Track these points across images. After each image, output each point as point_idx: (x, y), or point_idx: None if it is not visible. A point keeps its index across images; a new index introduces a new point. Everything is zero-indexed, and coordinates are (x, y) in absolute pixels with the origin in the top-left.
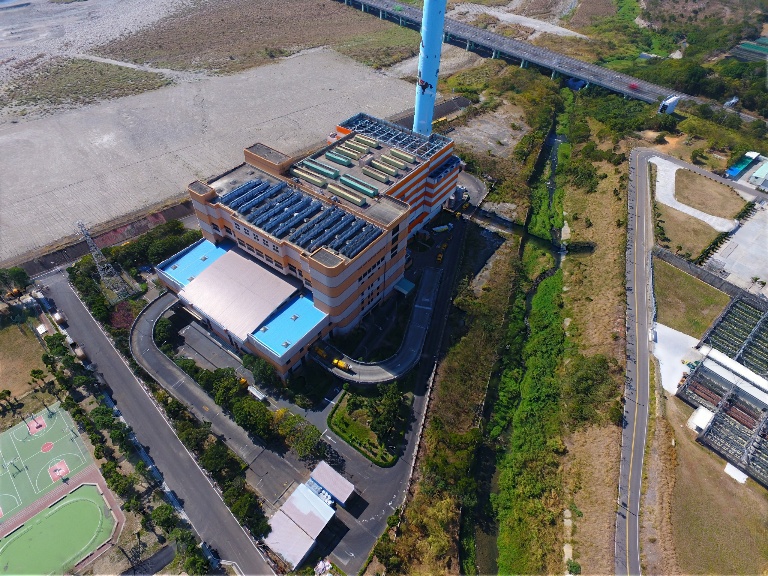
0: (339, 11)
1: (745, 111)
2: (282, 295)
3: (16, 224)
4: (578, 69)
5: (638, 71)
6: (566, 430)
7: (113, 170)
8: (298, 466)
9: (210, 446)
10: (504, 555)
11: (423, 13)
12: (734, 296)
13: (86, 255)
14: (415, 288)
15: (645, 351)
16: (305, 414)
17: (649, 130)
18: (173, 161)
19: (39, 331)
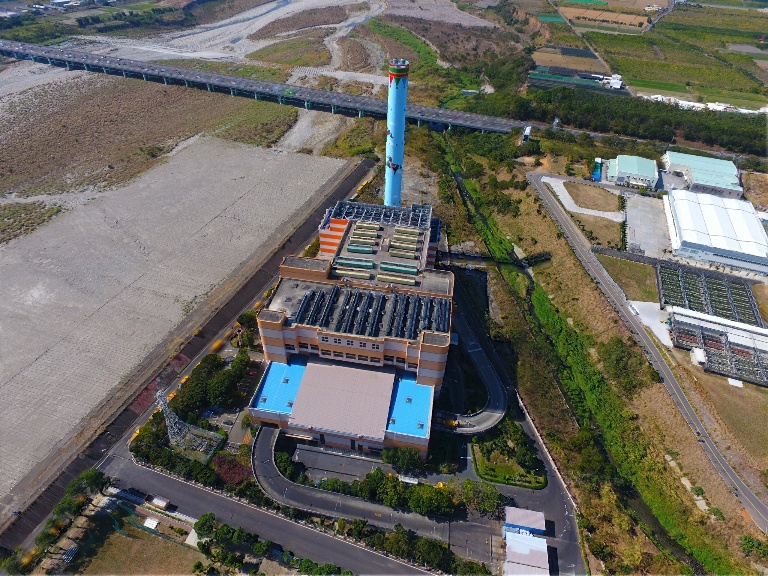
0: (185, 95)
1: (565, 126)
2: (387, 385)
3: (6, 427)
4: (437, 115)
5: (477, 108)
6: (626, 401)
7: (77, 326)
8: (485, 522)
9: (422, 542)
10: (656, 507)
11: (389, 112)
12: (654, 265)
13: (130, 427)
14: (458, 337)
15: (637, 324)
16: (457, 478)
17: (524, 156)
18: (140, 295)
19: (150, 527)
